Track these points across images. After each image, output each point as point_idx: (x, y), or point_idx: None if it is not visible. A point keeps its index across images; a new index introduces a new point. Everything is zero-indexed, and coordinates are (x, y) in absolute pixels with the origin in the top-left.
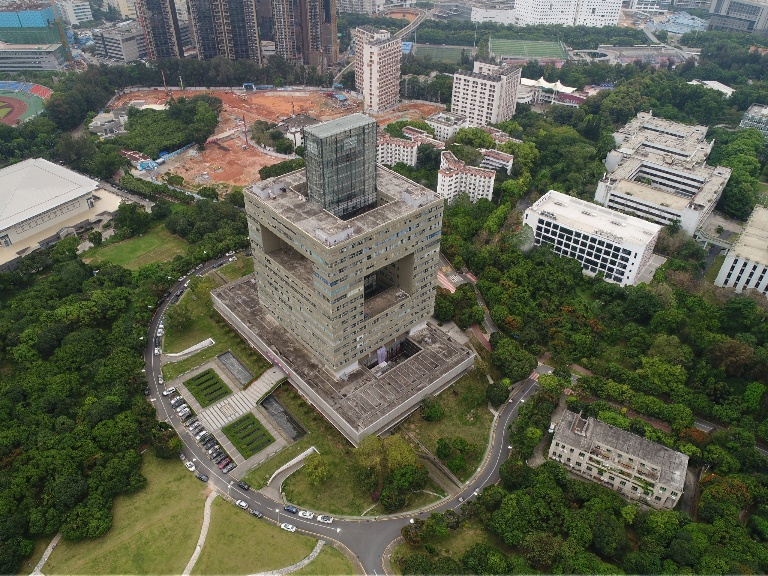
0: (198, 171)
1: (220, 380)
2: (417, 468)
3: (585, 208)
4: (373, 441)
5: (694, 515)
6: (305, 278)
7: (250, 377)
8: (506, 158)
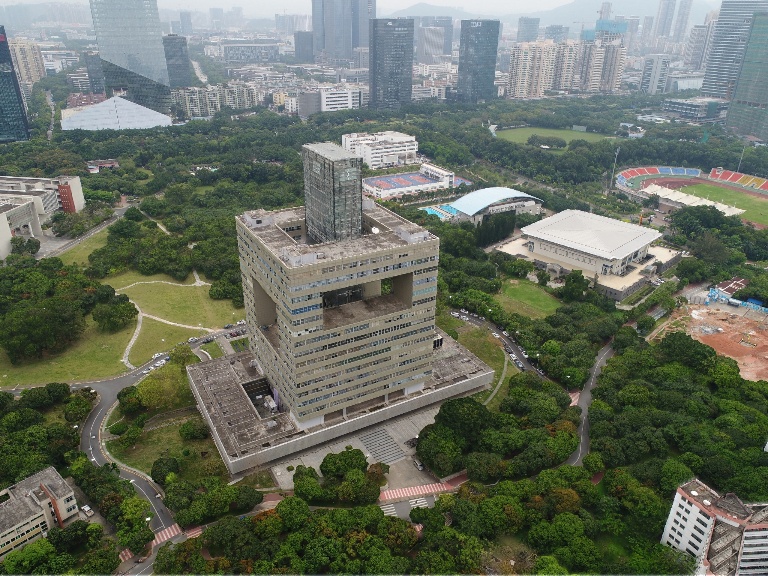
0: (727, 327)
1: None
2: (131, 398)
3: None
4: (169, 370)
5: None
6: None
7: None
8: None
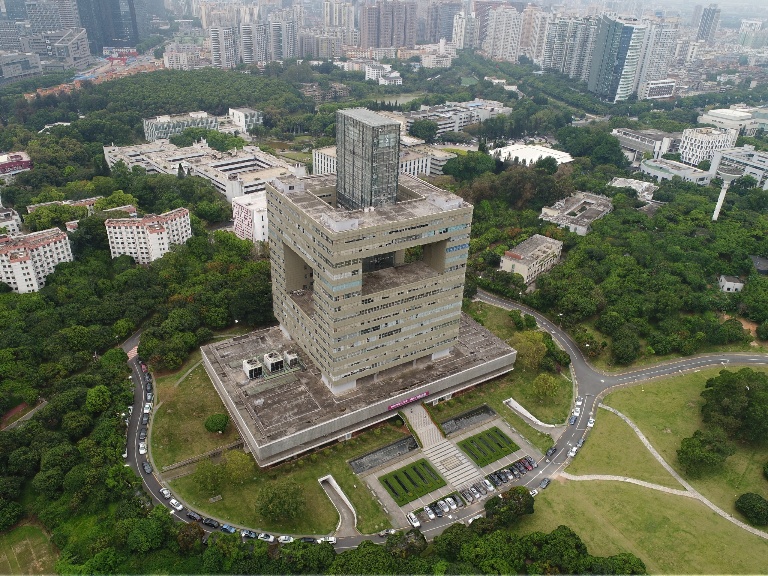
0: None
1: (402, 469)
2: (543, 333)
3: (264, 197)
4: None
5: (562, 254)
6: (415, 278)
7: (399, 444)
8: (131, 209)
